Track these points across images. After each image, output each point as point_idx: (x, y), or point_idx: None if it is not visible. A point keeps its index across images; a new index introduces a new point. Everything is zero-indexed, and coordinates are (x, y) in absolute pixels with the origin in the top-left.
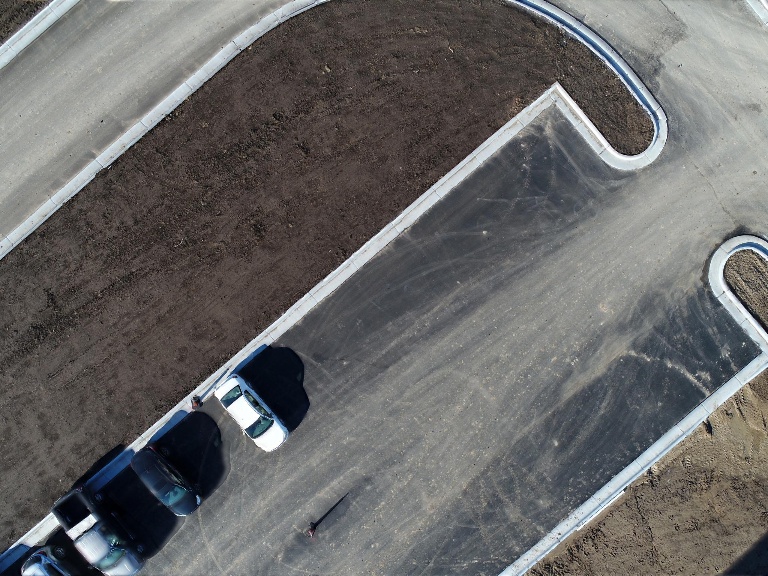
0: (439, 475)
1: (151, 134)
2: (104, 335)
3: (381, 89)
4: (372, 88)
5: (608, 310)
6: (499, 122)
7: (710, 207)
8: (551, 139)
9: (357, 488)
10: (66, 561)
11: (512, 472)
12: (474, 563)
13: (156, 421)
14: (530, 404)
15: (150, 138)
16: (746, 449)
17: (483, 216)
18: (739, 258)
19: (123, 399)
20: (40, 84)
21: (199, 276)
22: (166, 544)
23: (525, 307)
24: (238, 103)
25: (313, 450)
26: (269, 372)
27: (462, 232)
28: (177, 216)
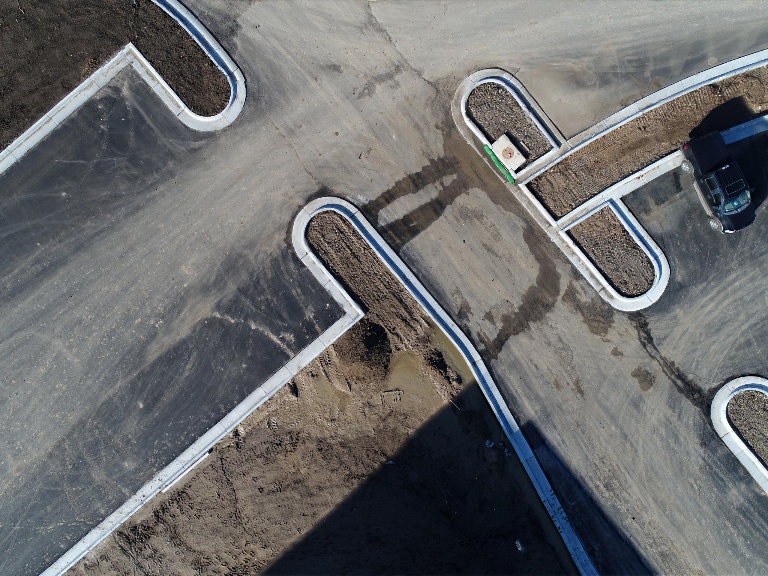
0: (24, 438)
1: None
2: None
3: None
4: None
5: (191, 272)
6: (73, 83)
7: (292, 168)
8: (129, 100)
9: None
10: None
11: (97, 434)
12: (59, 526)
13: None
14: (115, 366)
15: None
16: (333, 411)
17: (62, 178)
18: (322, 219)
19: None
20: None
21: None
22: None
23: (107, 269)
24: None
25: None
26: None
27: (41, 194)
28: None
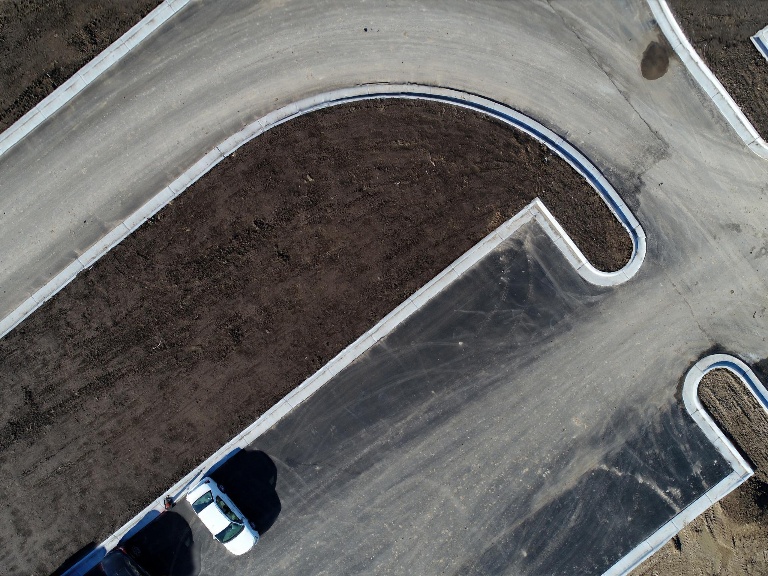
0: None
1: (133, 236)
2: (80, 434)
3: (362, 200)
4: (353, 198)
5: (581, 424)
6: (478, 235)
7: (686, 325)
8: (530, 253)
9: None
10: None
11: None
12: None
13: (128, 520)
14: (500, 514)
15: (132, 240)
16: (715, 566)
17: (459, 327)
18: (714, 376)
19: (97, 498)
20: (25, 183)
21: (176, 379)
22: None
23: (498, 418)
24: (220, 209)
25: (283, 553)
26: (242, 475)
27: (438, 342)
28: (156, 319)
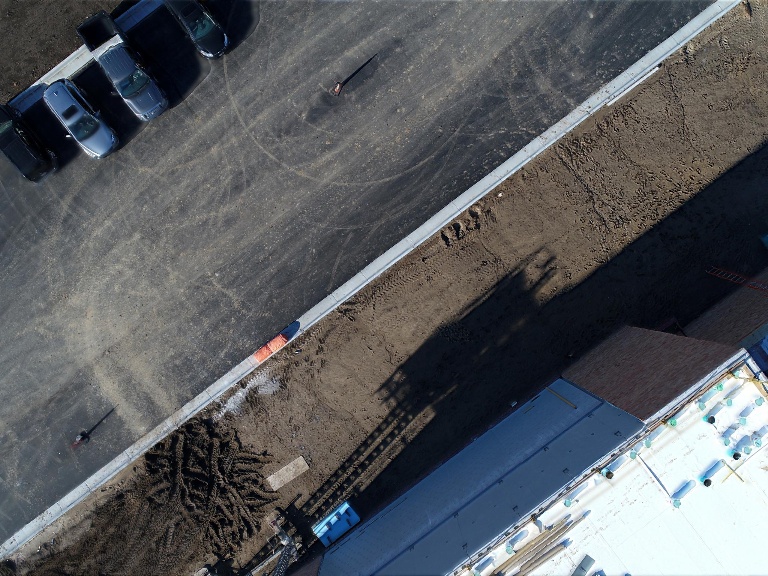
0: (470, 42)
1: None
2: None
3: None
4: None
5: None
6: None
7: None
8: None
9: (386, 49)
10: (88, 99)
11: (545, 43)
12: (501, 133)
13: None
14: None
15: None
16: None
17: None
18: None
19: None
20: None
21: None
22: (190, 94)
23: None
24: None
25: (344, 6)
26: None
27: None
28: None
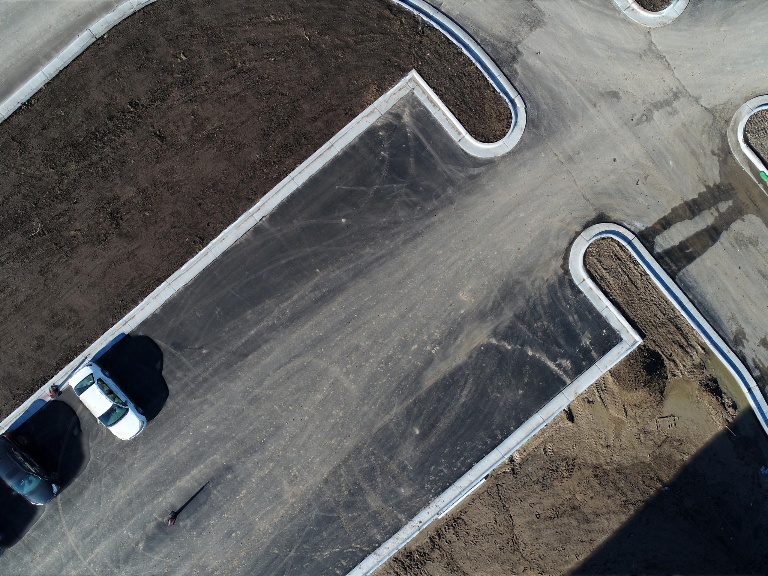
0: (300, 463)
1: (7, 122)
2: None
3: (237, 77)
4: (228, 76)
5: (468, 298)
6: (356, 110)
7: (570, 195)
8: (409, 127)
9: (218, 477)
10: None
11: (373, 460)
12: (335, 551)
13: (14, 410)
14: (391, 392)
15: (6, 126)
16: (608, 437)
17: (342, 204)
18: (599, 246)
19: None
20: None
21: (56, 264)
22: (26, 533)
23: (385, 295)
24: (94, 91)
25: (173, 439)
26: (128, 361)
27: (321, 220)
28: (33, 204)
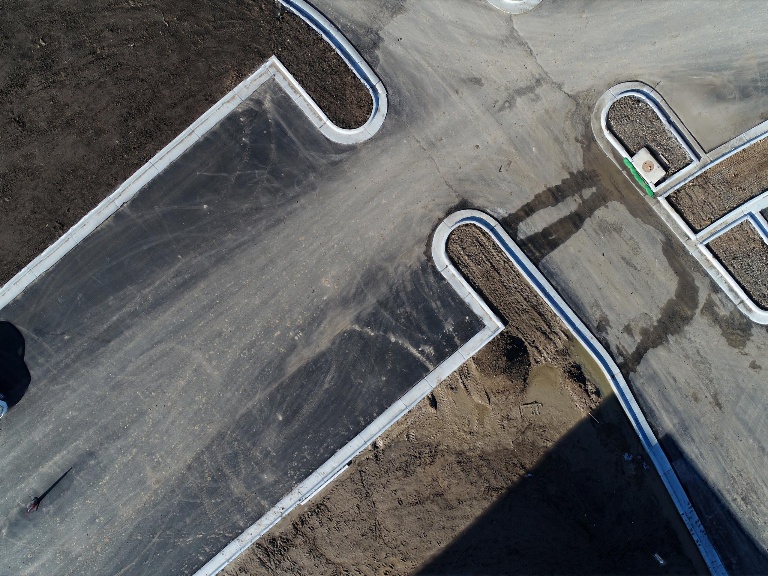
0: (163, 450)
1: None
2: None
3: (96, 63)
4: (87, 62)
5: (331, 284)
6: (216, 96)
7: (433, 181)
8: (270, 113)
9: (81, 463)
10: None
11: (236, 447)
12: (199, 538)
13: None
14: (254, 378)
15: None
16: (471, 423)
17: (203, 190)
18: (462, 232)
19: None
20: None
21: None
22: None
23: (247, 281)
24: None
25: (35, 425)
26: None
27: (182, 206)
28: None
